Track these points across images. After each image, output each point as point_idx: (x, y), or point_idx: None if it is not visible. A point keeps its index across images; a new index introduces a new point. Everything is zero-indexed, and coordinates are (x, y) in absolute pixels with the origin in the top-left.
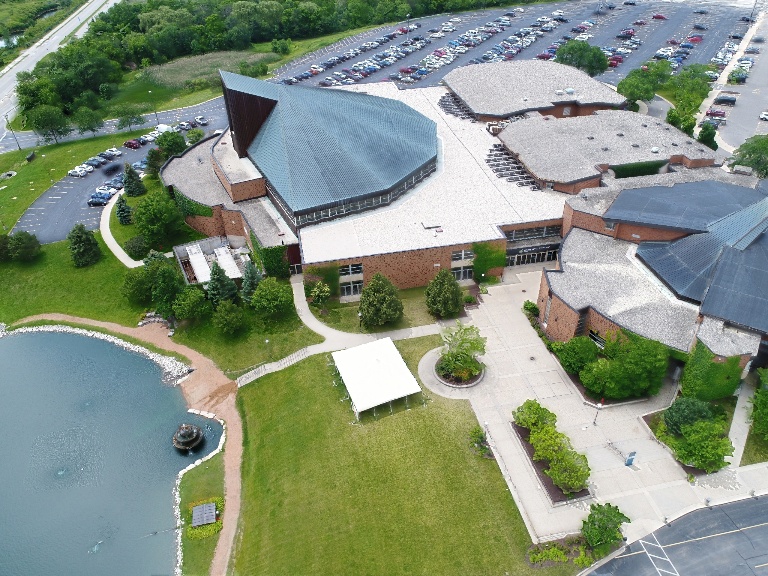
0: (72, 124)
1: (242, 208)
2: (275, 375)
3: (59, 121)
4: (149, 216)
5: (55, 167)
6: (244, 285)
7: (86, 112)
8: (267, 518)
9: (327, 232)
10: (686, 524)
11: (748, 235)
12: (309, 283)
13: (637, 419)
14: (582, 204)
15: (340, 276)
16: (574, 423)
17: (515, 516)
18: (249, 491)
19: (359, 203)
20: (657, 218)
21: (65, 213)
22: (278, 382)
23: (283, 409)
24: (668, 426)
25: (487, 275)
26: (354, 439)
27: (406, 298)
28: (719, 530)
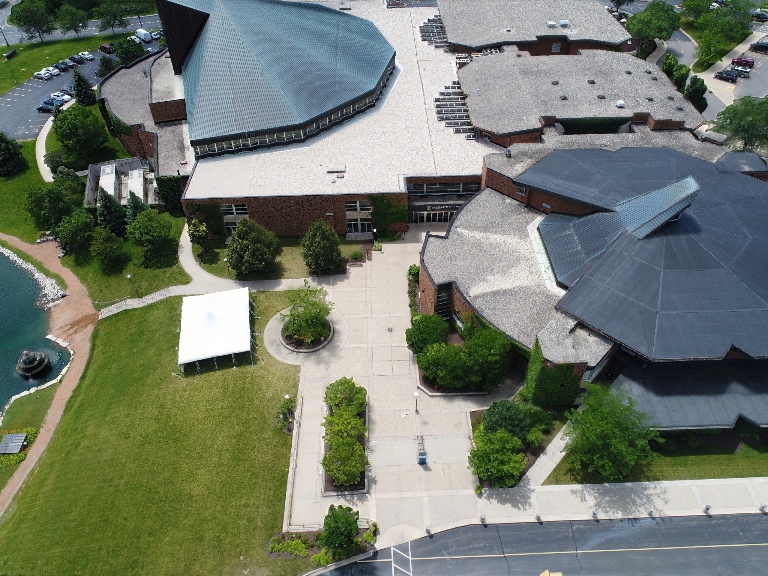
0: (55, 22)
1: (160, 130)
2: (133, 312)
3: (41, 18)
4: (65, 130)
5: (26, 67)
6: (128, 214)
7: (68, 10)
8: (61, 457)
9: (225, 166)
10: (450, 539)
11: (651, 221)
12: (191, 219)
13: (465, 413)
14: (500, 162)
15: (224, 215)
16: (396, 408)
17: (280, 499)
18: (63, 427)
19: (267, 137)
20: (569, 188)
21: (14, 117)
22: (132, 320)
23: (124, 348)
24: (483, 428)
25: (388, 230)
26: (169, 391)
27: (293, 246)
28: (482, 551)
